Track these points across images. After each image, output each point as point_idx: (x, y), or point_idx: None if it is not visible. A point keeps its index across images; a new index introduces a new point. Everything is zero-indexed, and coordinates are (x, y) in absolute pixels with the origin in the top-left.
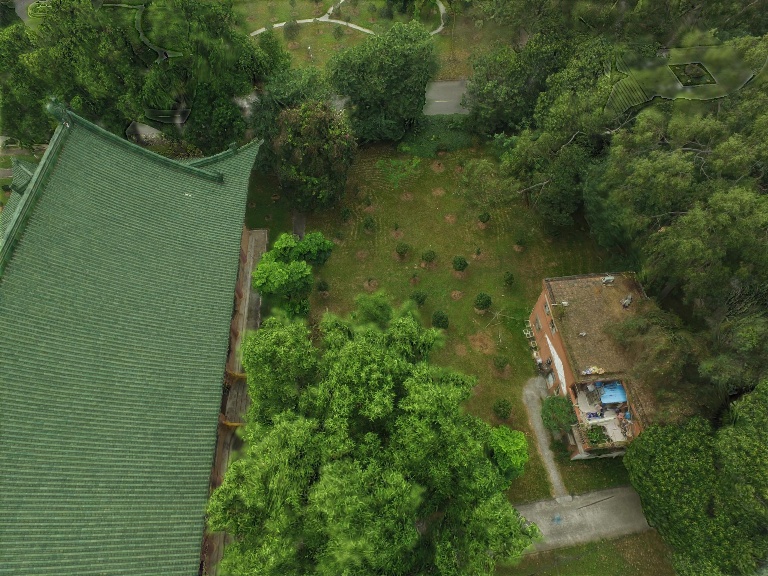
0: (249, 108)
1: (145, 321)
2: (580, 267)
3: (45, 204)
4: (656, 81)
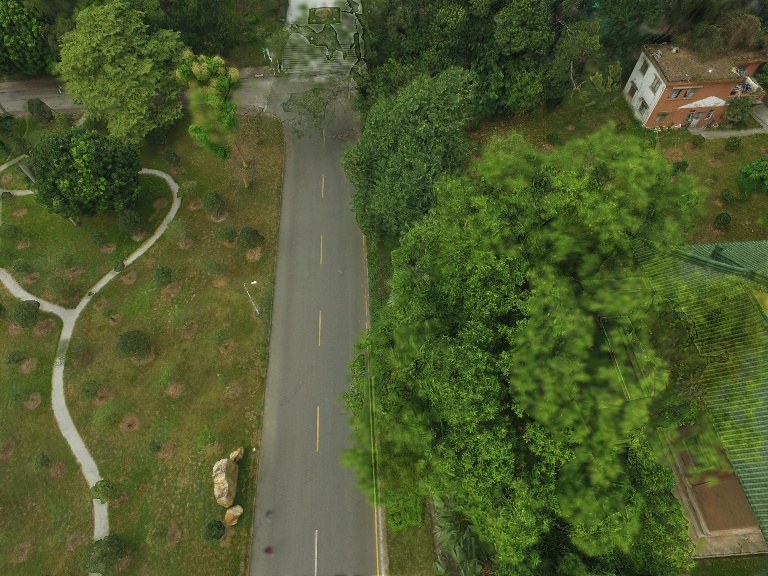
0: None
1: None
2: None
3: None
4: None
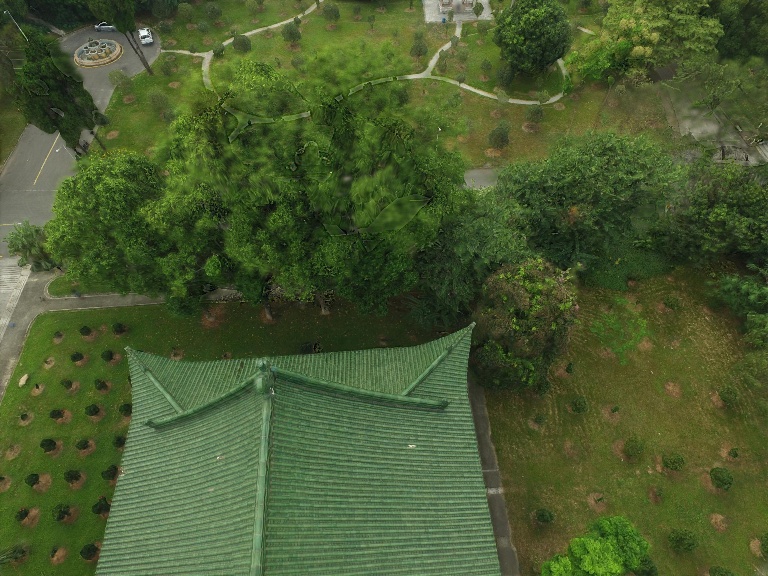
0: (424, 251)
1: None
2: None
3: (272, 574)
4: None
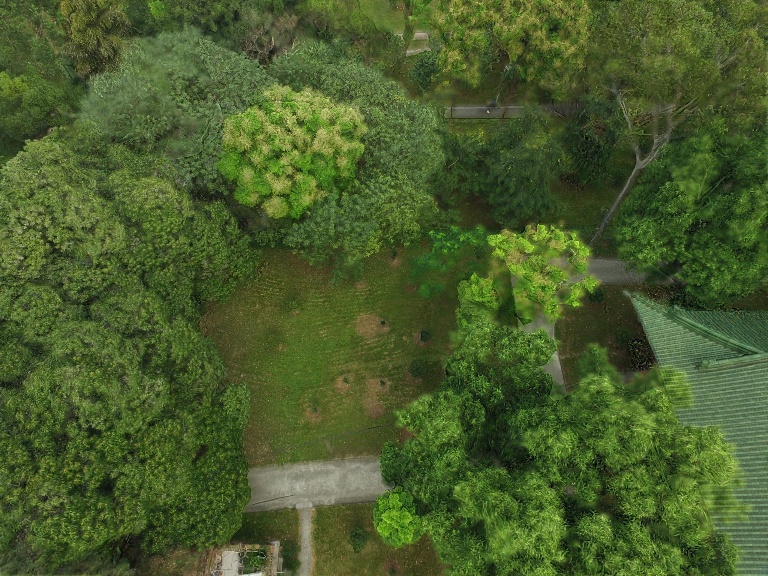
0: None
1: None
2: None
3: None
4: None
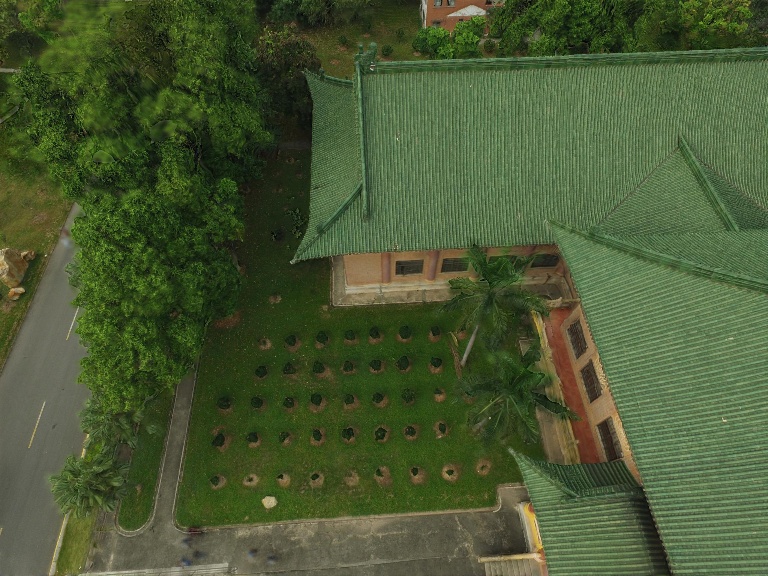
0: None
1: None
2: (385, 14)
3: None
4: None
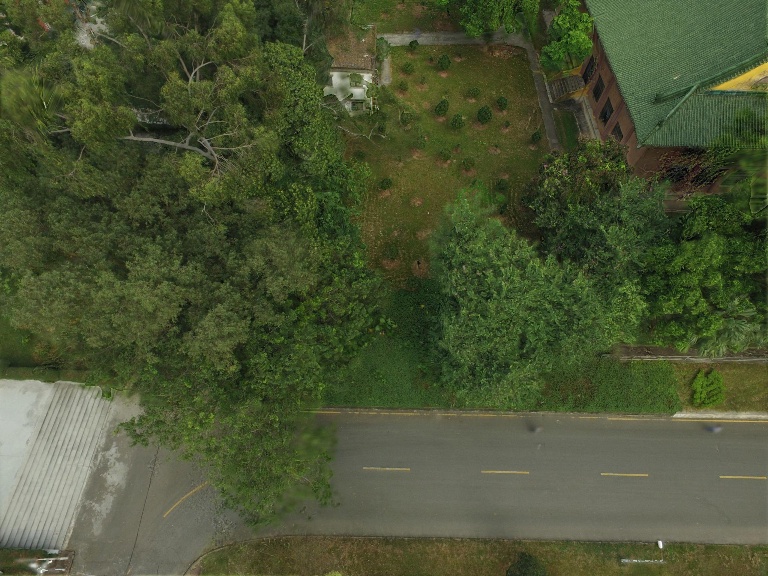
0: None
1: (650, 5)
2: None
3: None
4: (1, 445)
